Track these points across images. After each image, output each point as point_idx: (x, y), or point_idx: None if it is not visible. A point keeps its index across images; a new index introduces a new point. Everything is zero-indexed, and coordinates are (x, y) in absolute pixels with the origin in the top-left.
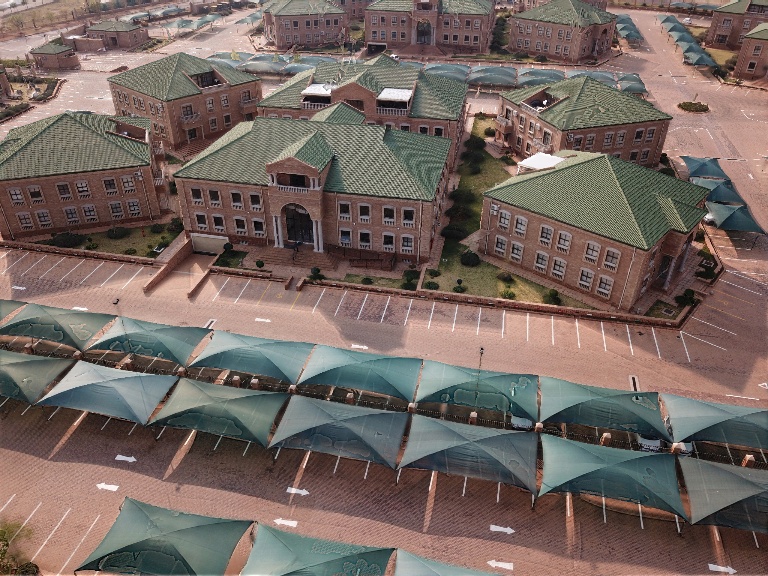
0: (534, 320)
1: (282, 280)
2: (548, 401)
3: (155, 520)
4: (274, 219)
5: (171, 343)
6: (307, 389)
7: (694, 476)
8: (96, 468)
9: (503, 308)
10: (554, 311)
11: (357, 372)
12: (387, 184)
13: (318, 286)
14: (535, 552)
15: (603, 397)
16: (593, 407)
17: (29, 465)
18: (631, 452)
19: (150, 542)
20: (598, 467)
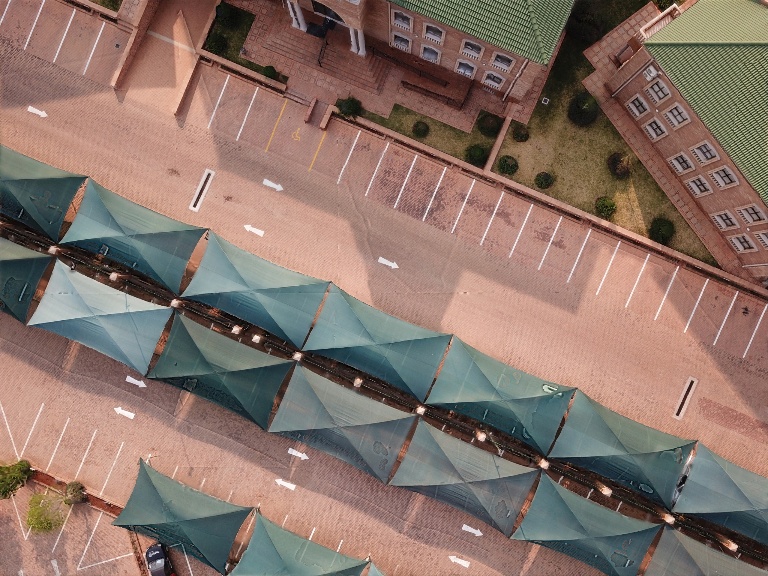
0: (622, 257)
1: (302, 101)
2: (569, 435)
3: (168, 505)
4: (288, 2)
5: (158, 261)
6: (313, 360)
7: (666, 552)
8: (110, 388)
9: (590, 226)
10: (655, 249)
11: (370, 357)
12: (479, 6)
13: (351, 125)
14: (492, 557)
15: (628, 454)
16: (610, 463)
17: (46, 372)
18: (619, 521)
19: (166, 526)
20: (576, 537)
